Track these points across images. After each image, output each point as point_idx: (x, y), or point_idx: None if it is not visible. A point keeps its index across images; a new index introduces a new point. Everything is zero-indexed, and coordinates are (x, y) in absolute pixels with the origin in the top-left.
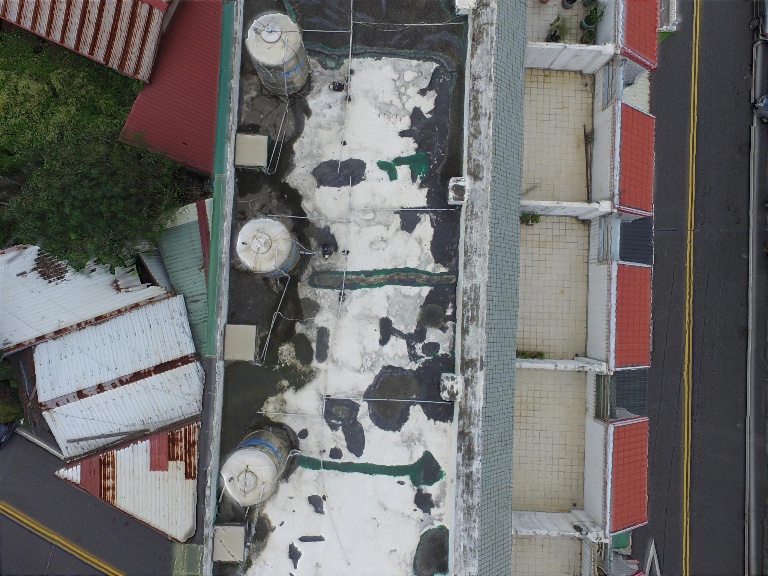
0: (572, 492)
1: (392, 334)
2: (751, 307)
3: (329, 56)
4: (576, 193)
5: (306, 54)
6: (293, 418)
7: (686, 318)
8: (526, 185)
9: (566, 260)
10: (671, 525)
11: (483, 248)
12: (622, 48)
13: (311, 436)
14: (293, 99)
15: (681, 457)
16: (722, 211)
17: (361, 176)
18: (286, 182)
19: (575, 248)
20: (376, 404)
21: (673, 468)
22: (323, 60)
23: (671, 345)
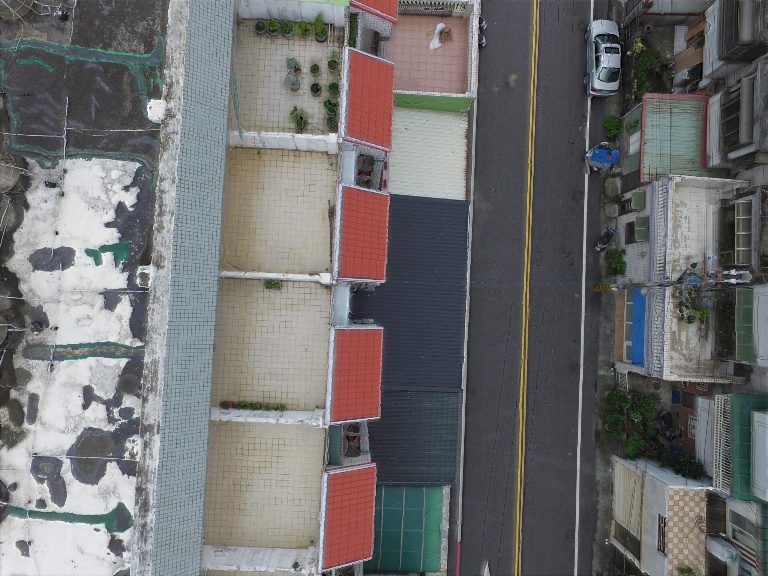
0: (310, 530)
1: (94, 400)
2: (583, 343)
3: (46, 157)
4: (320, 261)
5: (1, 164)
6: (4, 473)
7: (522, 353)
8: (276, 254)
9: (310, 321)
10: (505, 548)
11: (163, 328)
12: (344, 138)
13: (20, 489)
14: (13, 195)
15: (515, 484)
16: (557, 253)
17: (71, 262)
18: (6, 267)
19: (318, 310)
20: (77, 461)
21: (508, 494)
22: (41, 160)
23: (508, 379)
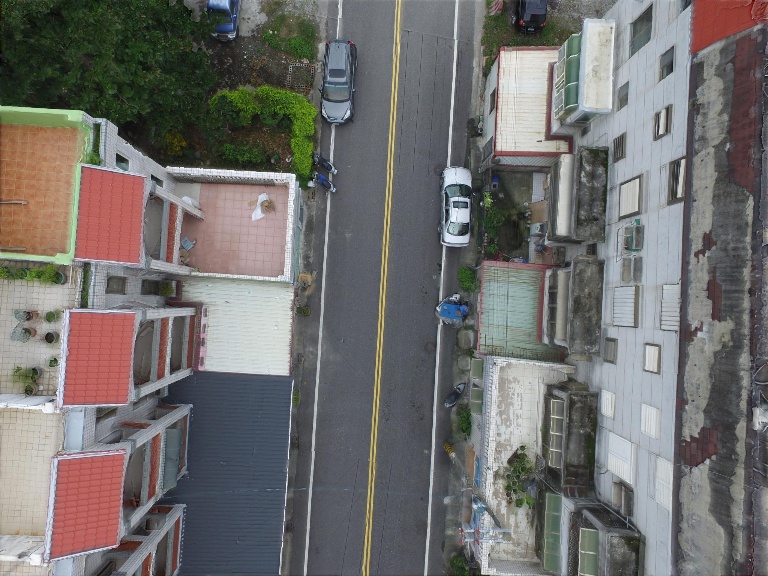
0: None
1: None
2: (431, 501)
3: None
4: None
5: None
6: None
7: (366, 512)
8: (7, 511)
9: None
10: None
11: None
12: None
13: None
14: None
15: None
16: (406, 408)
17: None
18: None
19: None
20: None
21: None
22: None
23: (352, 538)
